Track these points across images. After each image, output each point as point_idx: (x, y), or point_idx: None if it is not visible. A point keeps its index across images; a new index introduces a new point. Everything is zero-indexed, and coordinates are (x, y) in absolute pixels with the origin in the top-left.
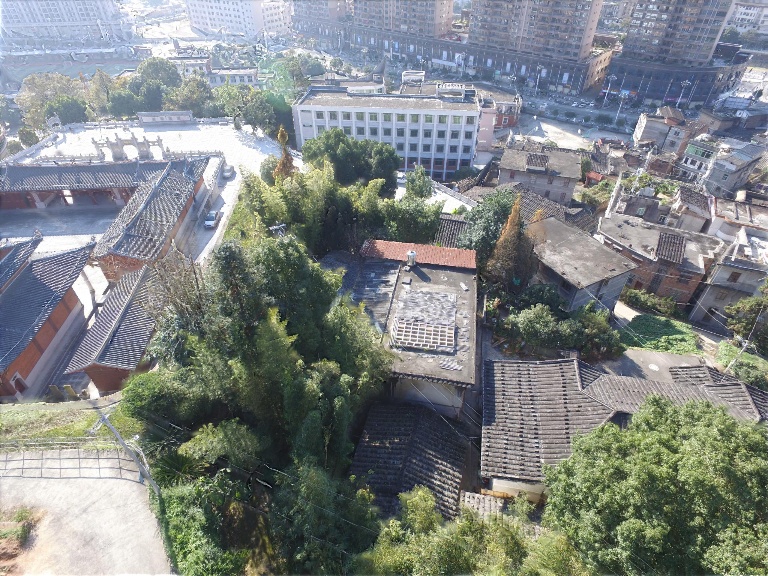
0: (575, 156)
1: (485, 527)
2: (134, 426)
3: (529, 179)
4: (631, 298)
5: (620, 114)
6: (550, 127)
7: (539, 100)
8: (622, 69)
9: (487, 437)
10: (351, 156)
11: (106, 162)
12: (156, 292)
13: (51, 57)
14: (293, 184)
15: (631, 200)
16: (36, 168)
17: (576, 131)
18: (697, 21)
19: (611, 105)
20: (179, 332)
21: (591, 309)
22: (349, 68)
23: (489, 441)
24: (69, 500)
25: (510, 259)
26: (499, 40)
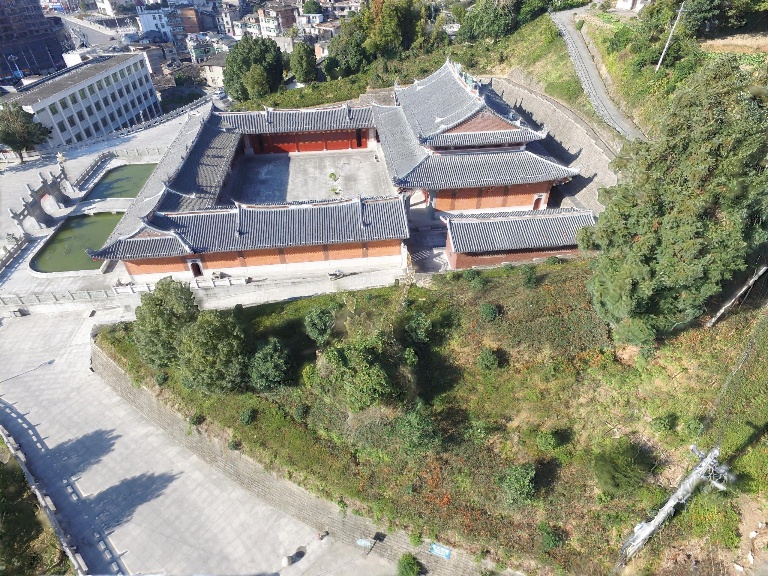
0: None
1: None
2: None
3: None
4: None
5: None
6: None
7: None
8: None
9: None
10: None
11: (196, 136)
12: None
13: None
14: None
15: None
16: (180, 174)
17: None
18: None
19: None
20: None
21: None
22: None
23: None
24: None
25: None
26: None
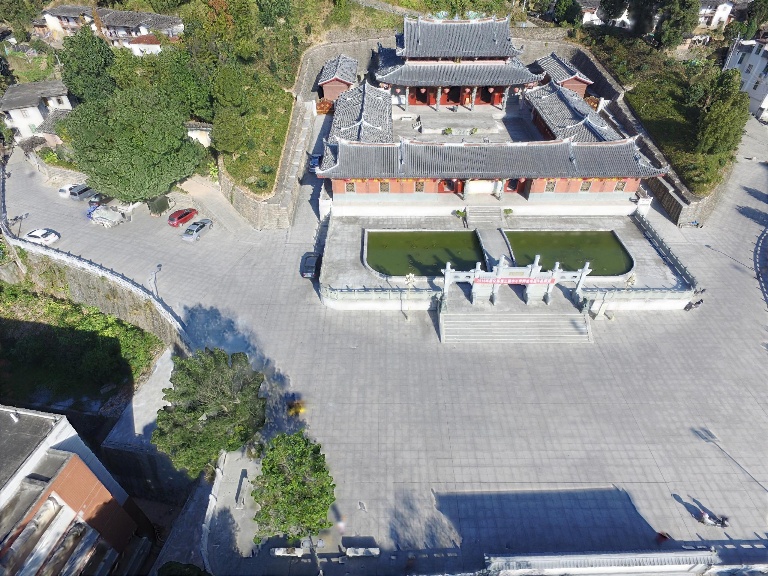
0: None
1: None
2: None
3: None
4: None
5: None
6: None
7: None
8: None
9: None
10: None
11: None
12: None
13: None
14: None
15: None
16: None
17: None
18: None
19: None
20: None
21: None
22: None
23: None
24: None
25: None
26: None
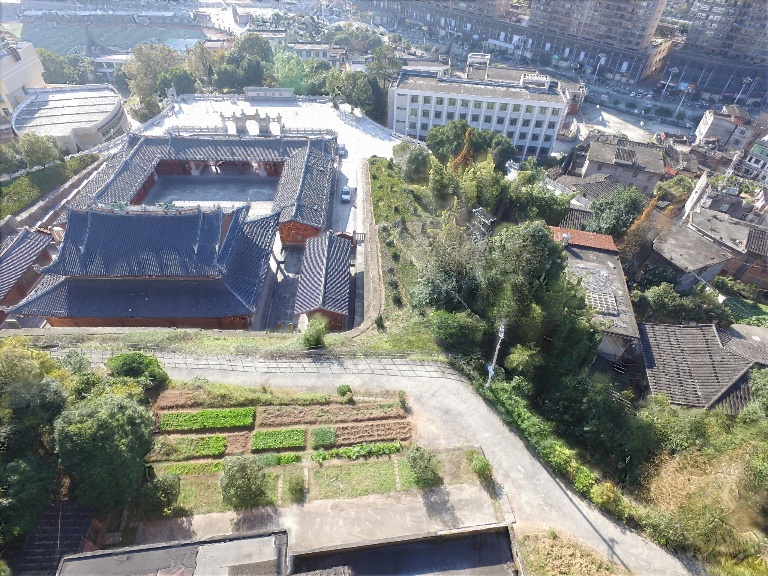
0: (657, 152)
1: (701, 420)
2: (434, 347)
3: (615, 171)
4: (718, 283)
5: (681, 108)
6: (611, 117)
7: (597, 88)
8: (683, 61)
9: (652, 376)
10: (476, 145)
11: (254, 138)
12: (437, 256)
13: (114, 18)
14: (478, 174)
15: (717, 197)
16: (194, 140)
17: (637, 122)
18: (764, 18)
19: (673, 98)
20: (457, 285)
21: (702, 289)
22: (409, 45)
23: (655, 379)
24: (418, 389)
25: (639, 245)
26: (560, 25)
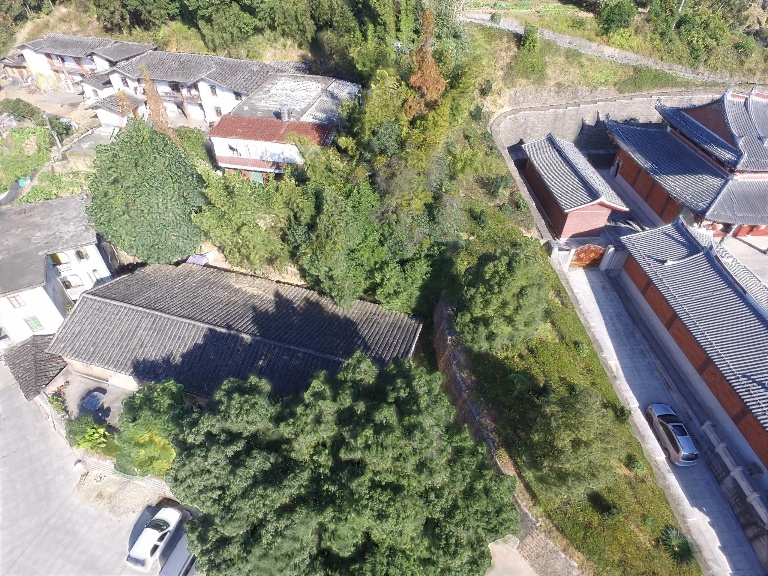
0: None
1: None
2: None
3: None
4: None
5: None
6: None
7: None
8: None
9: None
10: None
11: None
12: None
13: None
14: None
15: None
16: None
17: None
18: None
19: None
20: None
21: None
22: None
23: None
24: None
25: None
26: None
